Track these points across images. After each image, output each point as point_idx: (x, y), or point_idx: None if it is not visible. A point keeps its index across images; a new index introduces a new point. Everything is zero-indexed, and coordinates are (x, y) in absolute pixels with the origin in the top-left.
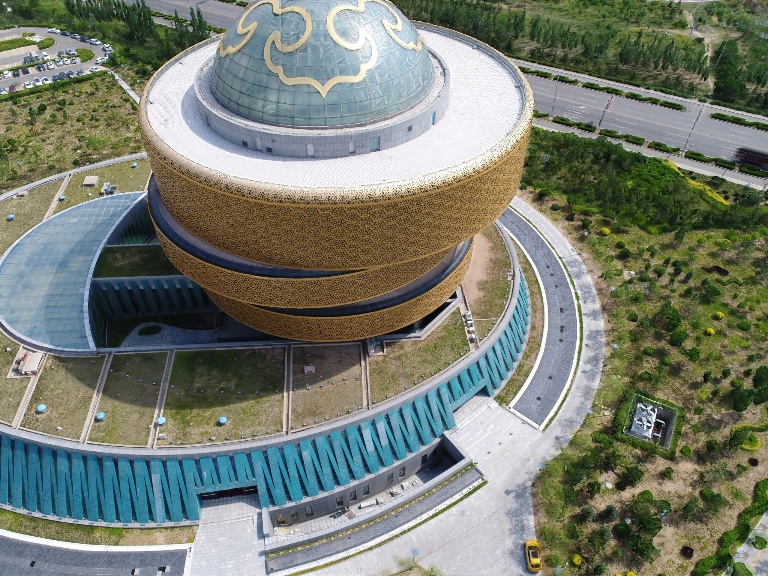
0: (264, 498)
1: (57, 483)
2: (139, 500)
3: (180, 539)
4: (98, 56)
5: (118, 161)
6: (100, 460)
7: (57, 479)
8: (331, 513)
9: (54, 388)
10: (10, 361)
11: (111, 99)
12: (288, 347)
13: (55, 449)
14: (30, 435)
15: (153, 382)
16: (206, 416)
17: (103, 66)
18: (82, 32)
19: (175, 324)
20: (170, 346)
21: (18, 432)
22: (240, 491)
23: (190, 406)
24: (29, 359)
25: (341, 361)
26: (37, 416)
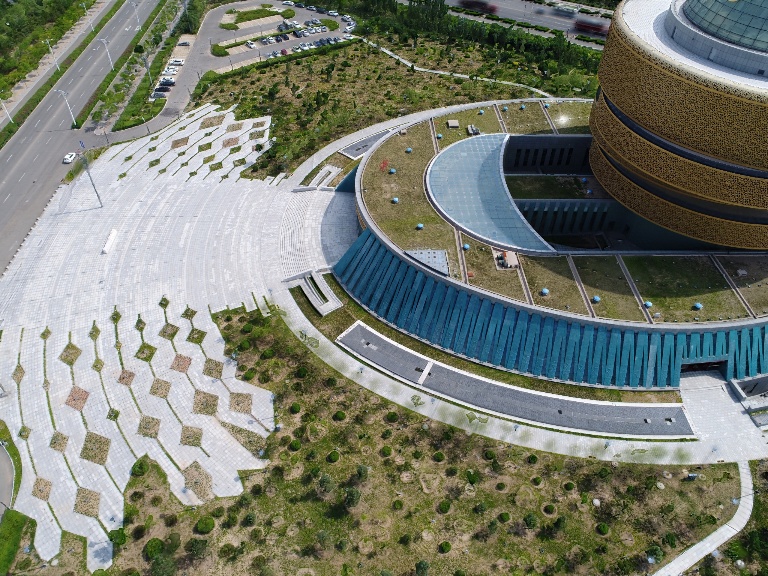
0: (731, 371)
1: (566, 351)
2: (635, 367)
3: (670, 400)
4: (342, 26)
5: (464, 109)
6: (608, 332)
7: (567, 348)
8: (760, 393)
9: (541, 278)
10: (490, 257)
11: (383, 62)
12: (712, 256)
13: (570, 322)
14: (549, 310)
15: (619, 277)
16: (680, 303)
17: (353, 34)
18: (314, 5)
19: (564, 243)
20: (614, 251)
21: (538, 308)
22: (702, 367)
23: (662, 295)
24: (508, 256)
25: (762, 268)
26: (543, 297)
